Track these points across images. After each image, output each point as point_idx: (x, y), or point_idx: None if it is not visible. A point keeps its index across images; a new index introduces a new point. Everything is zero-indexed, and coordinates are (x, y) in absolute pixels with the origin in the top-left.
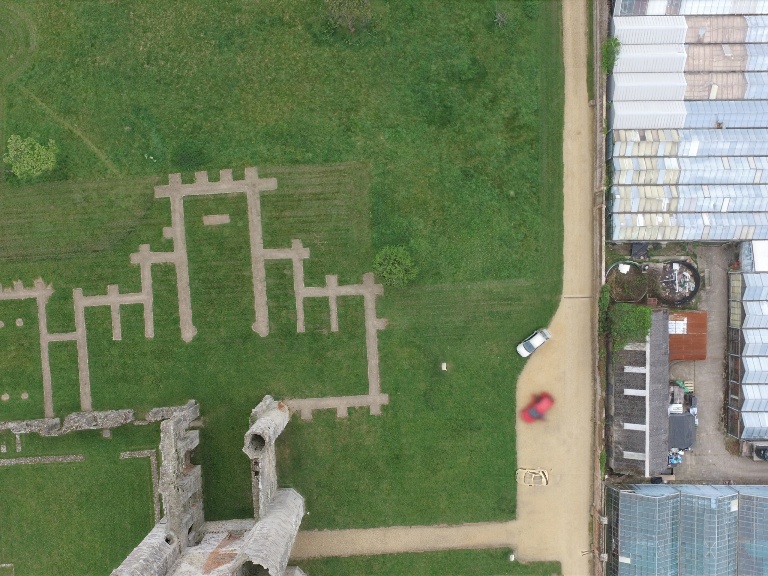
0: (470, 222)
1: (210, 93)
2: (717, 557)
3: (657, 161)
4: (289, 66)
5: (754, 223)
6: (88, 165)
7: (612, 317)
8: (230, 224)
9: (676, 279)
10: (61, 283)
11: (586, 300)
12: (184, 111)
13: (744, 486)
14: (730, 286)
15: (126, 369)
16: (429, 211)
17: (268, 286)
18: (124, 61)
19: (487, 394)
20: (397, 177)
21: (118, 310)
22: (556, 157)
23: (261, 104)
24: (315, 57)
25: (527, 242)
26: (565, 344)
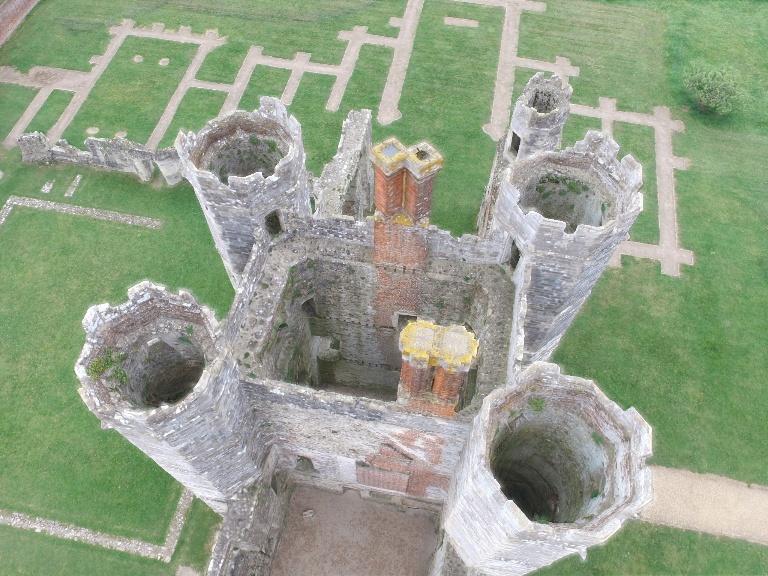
0: None
1: None
2: None
3: None
4: None
5: None
6: None
7: None
8: (478, 28)
9: None
10: (240, 38)
11: None
12: None
13: None
14: None
15: None
16: (748, 65)
17: (516, 91)
18: None
19: None
20: (702, 30)
21: (300, 76)
22: None
23: None
24: None
25: None
26: None
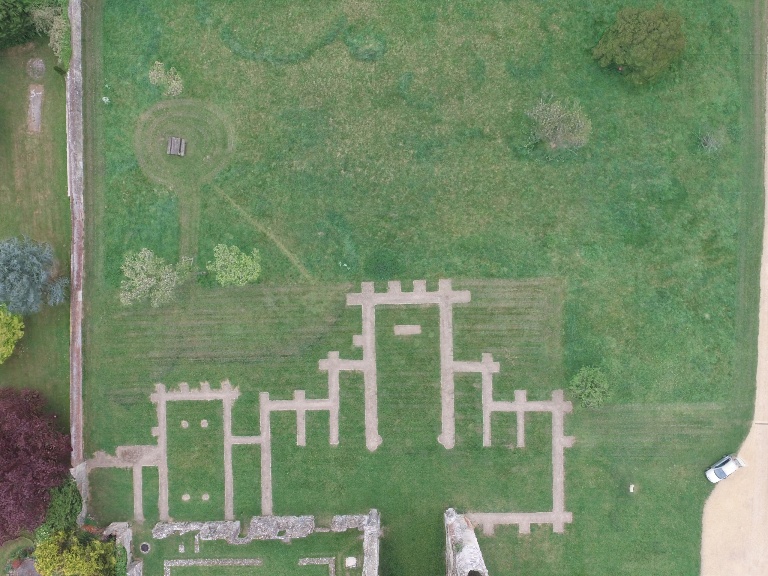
0: (664, 343)
1: (406, 202)
2: None
3: None
4: (487, 179)
5: None
6: (280, 269)
7: None
8: (421, 335)
9: None
10: (248, 386)
11: None
12: (379, 219)
13: None
14: None
15: (309, 475)
16: (622, 330)
17: (456, 399)
18: (321, 167)
19: (673, 517)
20: (591, 295)
21: (303, 415)
22: (753, 281)
23: (457, 215)
24: (514, 171)
25: (720, 366)
26: (754, 470)
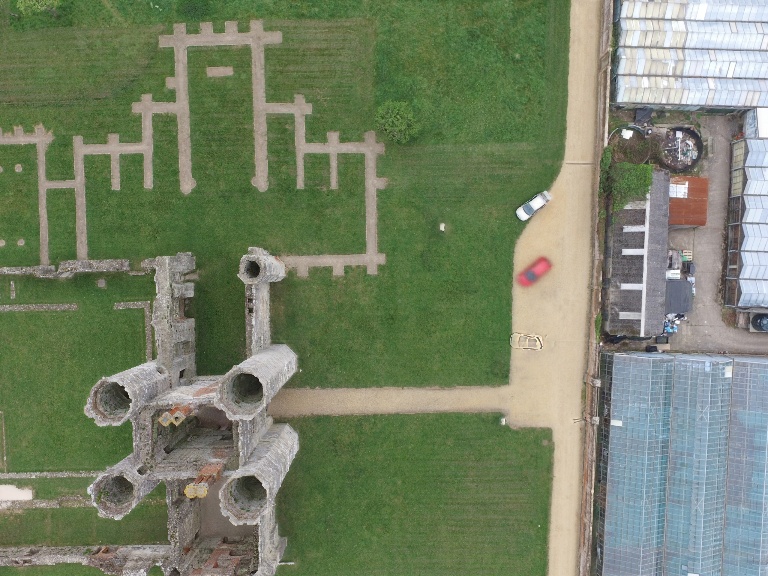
0: (474, 83)
1: None
2: (709, 421)
3: (664, 23)
4: None
5: (759, 89)
6: (93, 12)
7: (613, 175)
8: (233, 76)
9: (679, 147)
10: (62, 130)
11: (588, 166)
12: None
13: (739, 355)
14: (733, 156)
15: (123, 219)
16: (433, 71)
17: (269, 140)
18: None
19: (485, 257)
20: (403, 35)
21: (118, 159)
22: (563, 21)
23: None
24: None
25: (531, 106)
26: (565, 210)
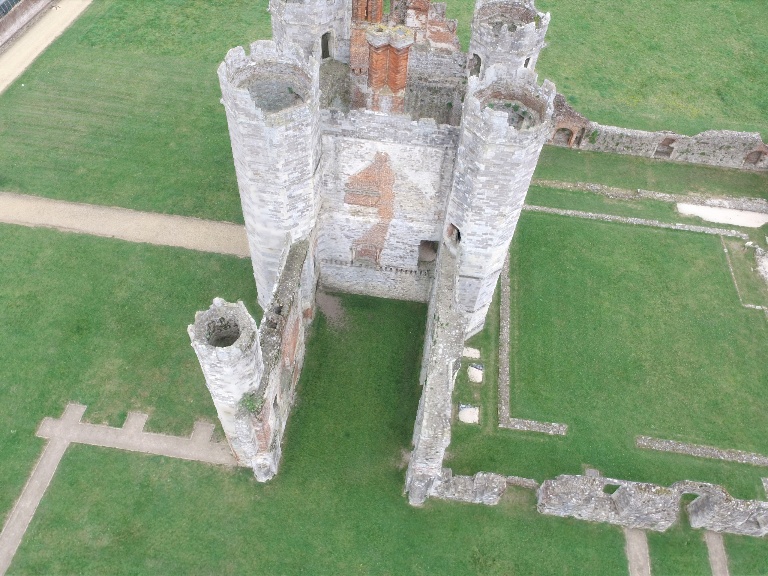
0: None
1: None
2: None
3: None
4: None
5: None
6: None
7: None
8: None
9: None
10: None
11: None
12: None
13: None
14: None
15: None
16: None
17: None
18: None
19: None
20: None
21: None
22: None
23: None
24: None
25: None
26: None
